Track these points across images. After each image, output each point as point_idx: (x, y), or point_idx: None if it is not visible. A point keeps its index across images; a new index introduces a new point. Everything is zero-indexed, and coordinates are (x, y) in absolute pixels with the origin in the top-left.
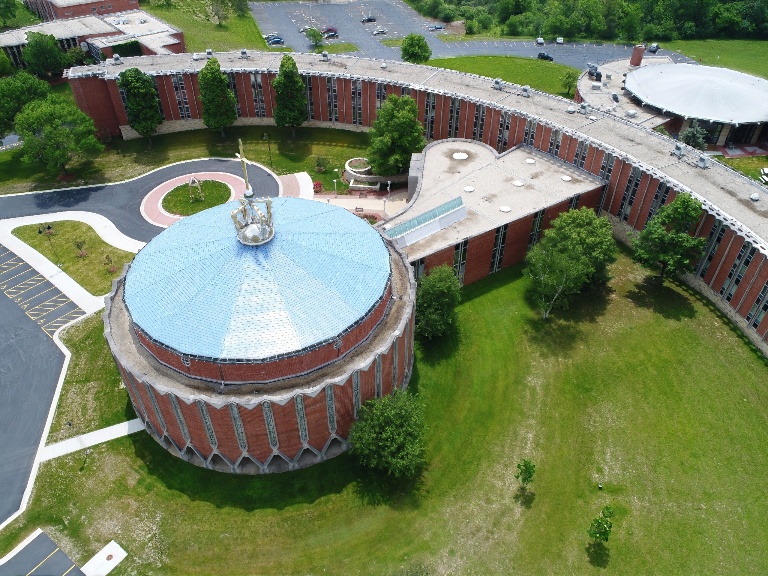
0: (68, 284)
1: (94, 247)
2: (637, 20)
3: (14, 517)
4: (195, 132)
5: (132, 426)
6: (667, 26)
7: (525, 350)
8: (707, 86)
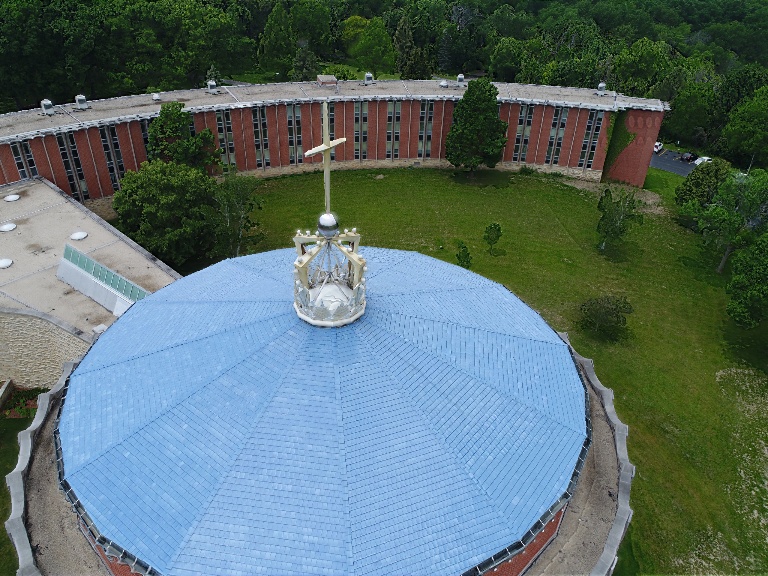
0: None
1: None
2: None
3: None
4: None
5: None
6: None
7: None
8: None
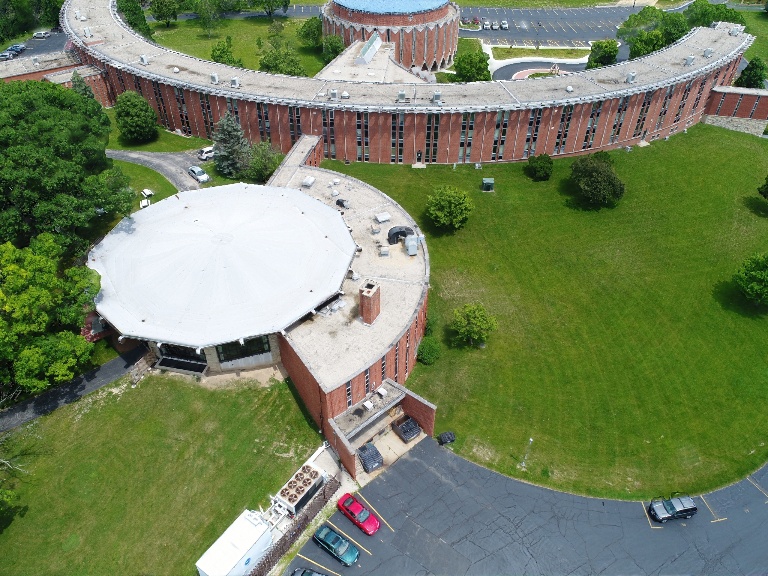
0: None
1: None
2: None
3: None
4: None
5: None
6: None
7: None
8: (225, 227)
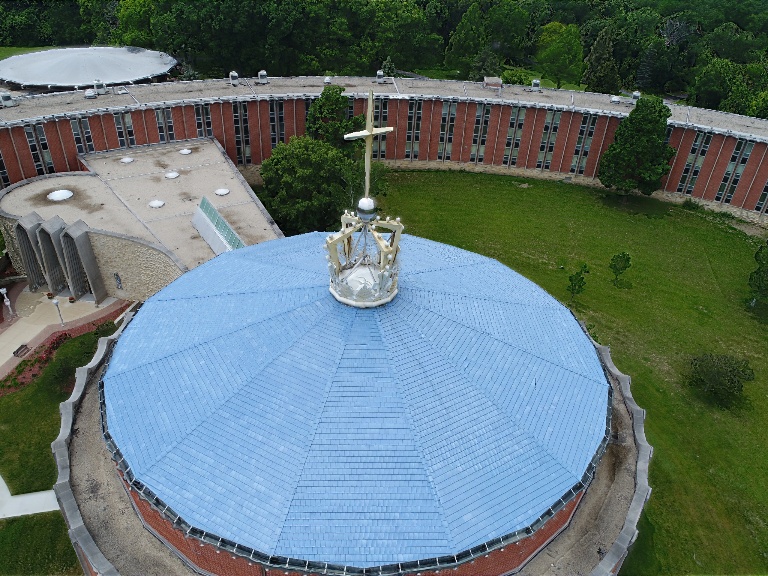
0: None
1: None
2: None
3: None
4: None
5: None
6: None
7: None
8: (92, 57)
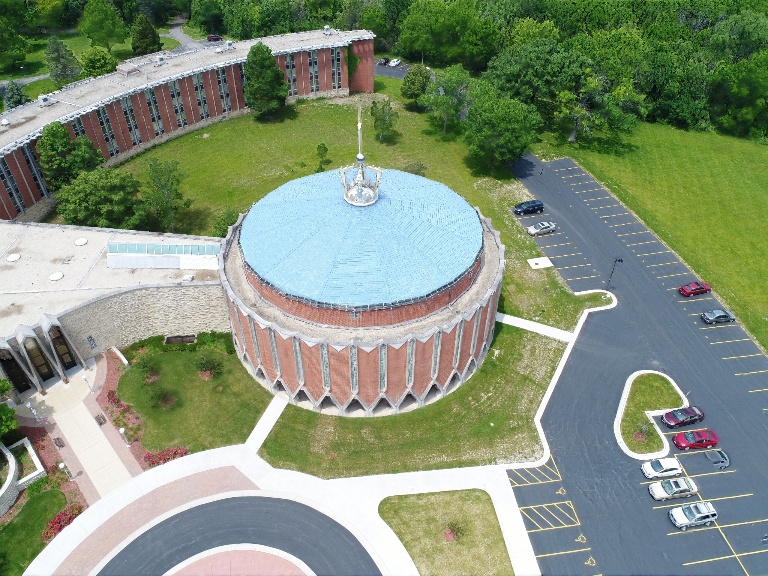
0: (518, 548)
1: None
2: None
3: (592, 309)
4: None
5: (500, 317)
6: None
7: None
8: None
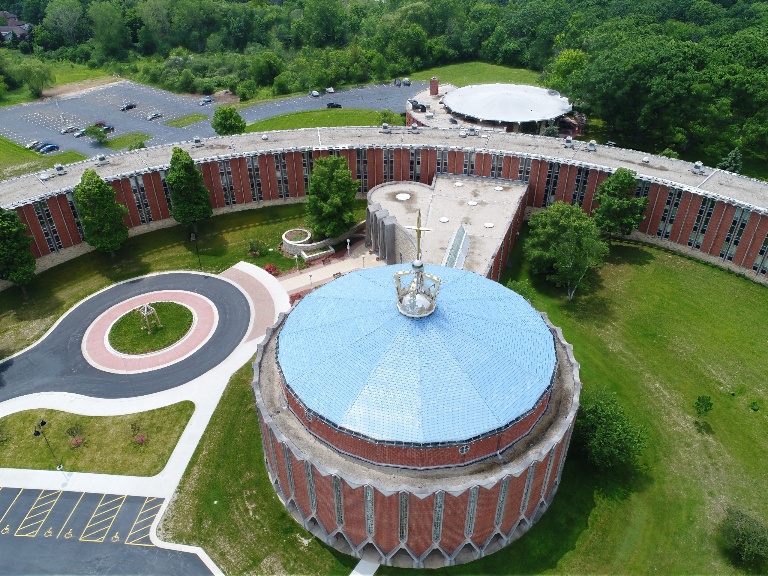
0: (99, 481)
1: (85, 428)
2: (384, 62)
3: None
4: (73, 262)
5: (364, 571)
6: (405, 63)
7: (583, 329)
8: (509, 97)
